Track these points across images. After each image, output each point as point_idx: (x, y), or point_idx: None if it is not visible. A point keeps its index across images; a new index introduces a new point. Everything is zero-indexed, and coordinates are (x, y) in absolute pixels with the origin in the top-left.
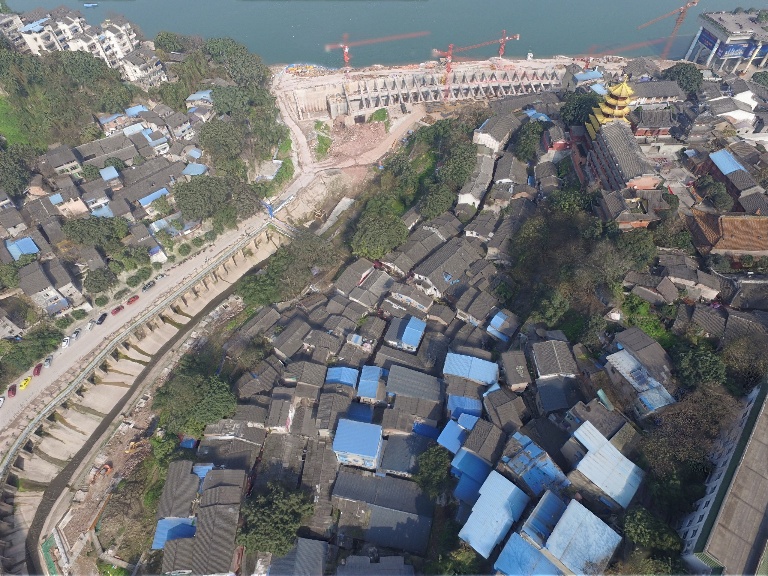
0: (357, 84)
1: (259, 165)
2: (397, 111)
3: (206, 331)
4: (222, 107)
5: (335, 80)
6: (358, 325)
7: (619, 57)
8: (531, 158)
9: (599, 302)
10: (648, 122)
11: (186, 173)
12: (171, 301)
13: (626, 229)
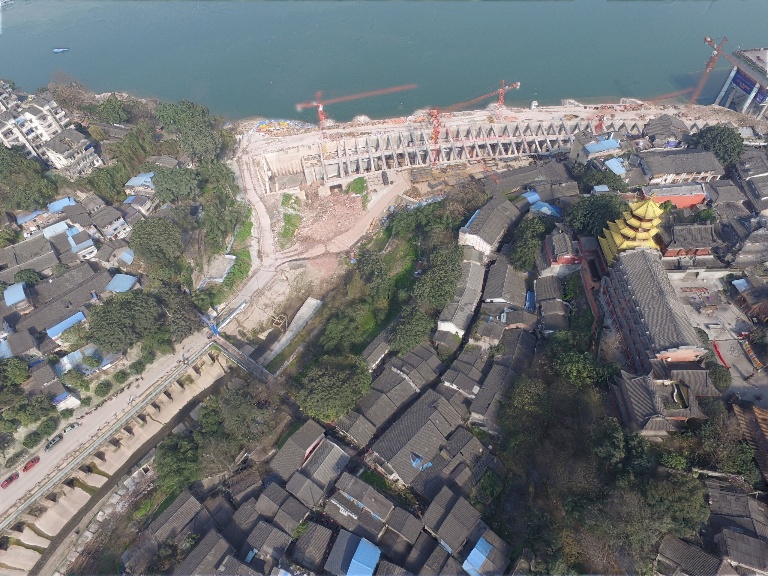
0: (335, 144)
1: (208, 262)
2: (377, 181)
3: (116, 510)
4: (164, 195)
5: (310, 140)
6: (294, 537)
7: (638, 102)
8: (530, 269)
9: (621, 569)
10: (682, 242)
11: (110, 289)
12: (79, 463)
13: (658, 436)
